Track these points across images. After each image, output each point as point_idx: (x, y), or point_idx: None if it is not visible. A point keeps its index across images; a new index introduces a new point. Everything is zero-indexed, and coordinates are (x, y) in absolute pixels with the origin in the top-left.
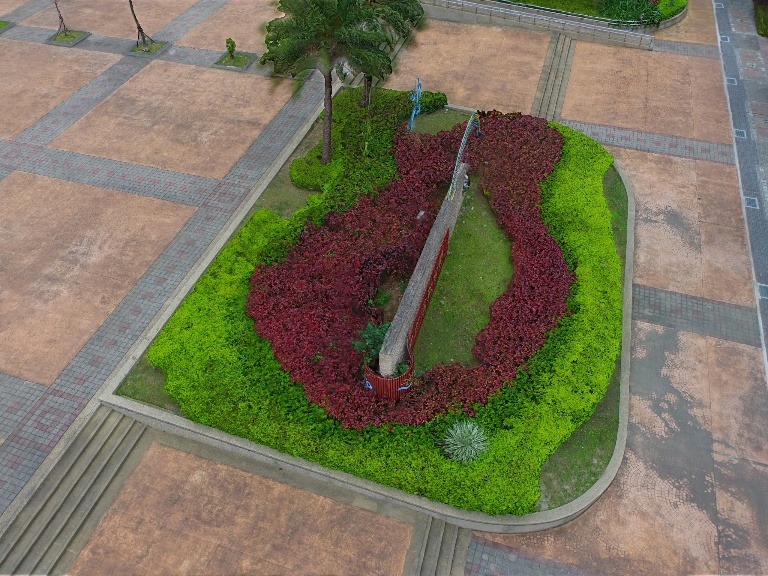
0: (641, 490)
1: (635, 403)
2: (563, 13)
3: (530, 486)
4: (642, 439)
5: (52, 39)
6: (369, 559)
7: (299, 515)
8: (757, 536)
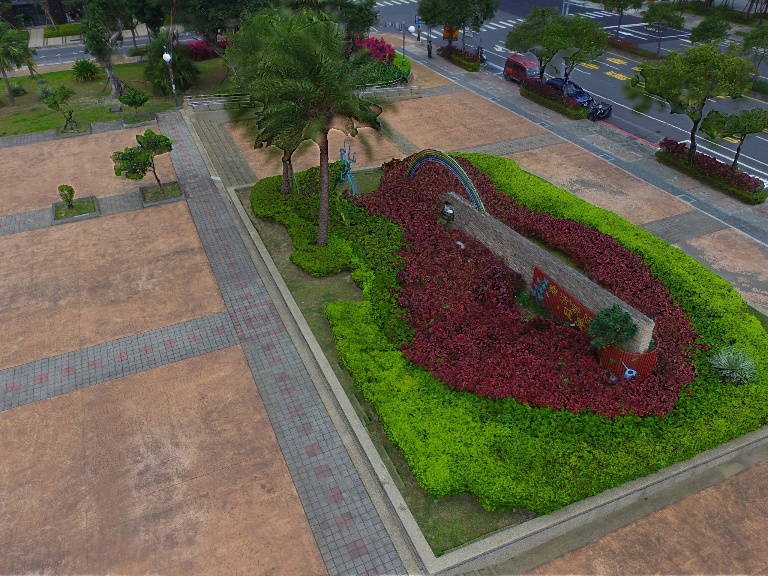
0: None
1: None
2: None
3: None
4: (767, 310)
5: None
6: None
7: (713, 519)
8: None
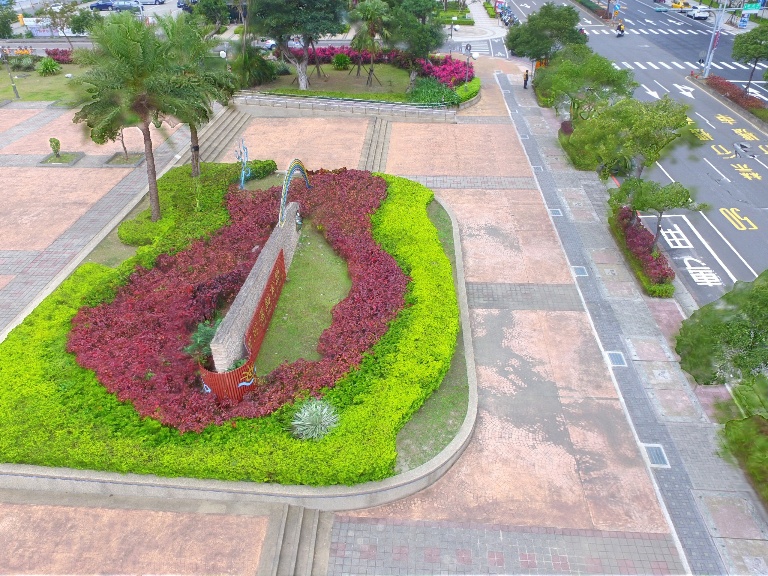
0: (499, 441)
1: (482, 372)
2: (377, 102)
3: (385, 447)
4: (494, 399)
5: None
6: (219, 560)
7: (134, 536)
8: (611, 456)
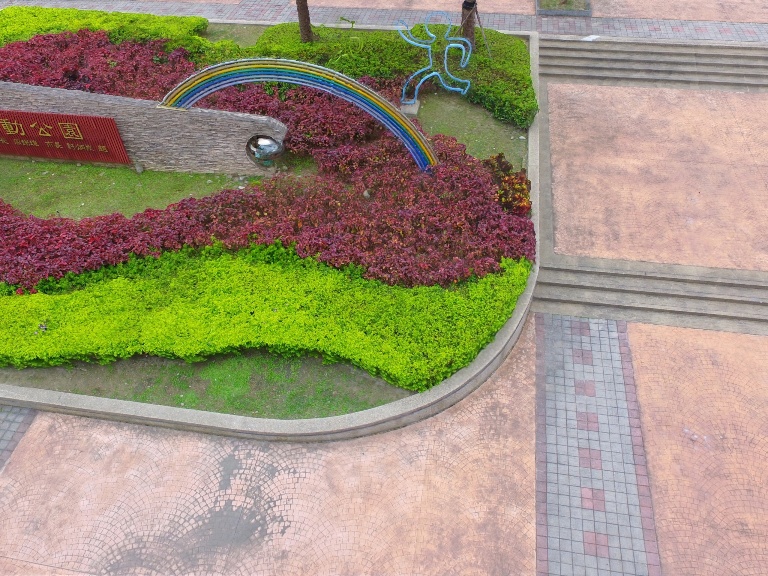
0: None
1: None
2: None
3: None
4: None
5: None
6: None
7: None
8: None
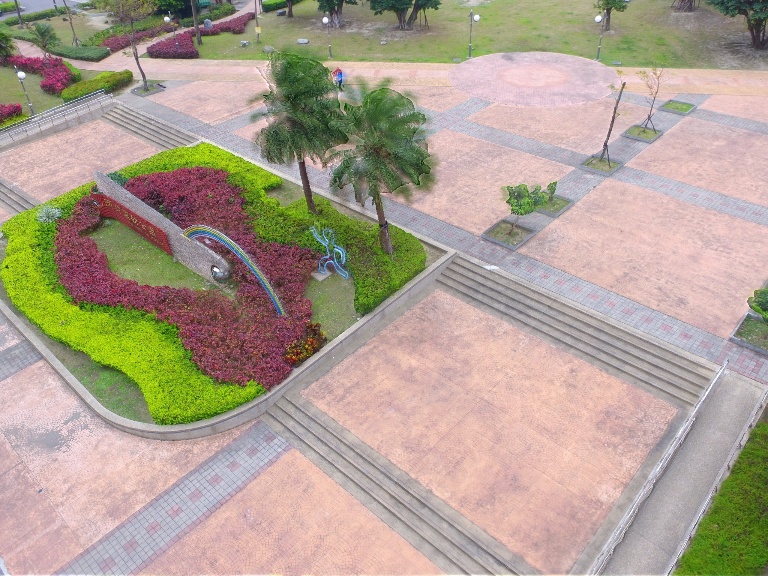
0: None
1: None
2: None
3: (7, 227)
4: None
5: (638, 126)
6: None
7: None
8: None
